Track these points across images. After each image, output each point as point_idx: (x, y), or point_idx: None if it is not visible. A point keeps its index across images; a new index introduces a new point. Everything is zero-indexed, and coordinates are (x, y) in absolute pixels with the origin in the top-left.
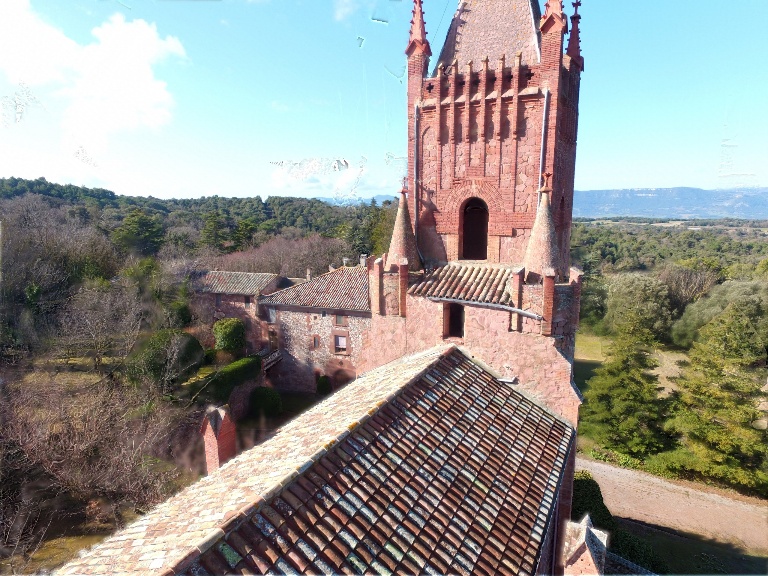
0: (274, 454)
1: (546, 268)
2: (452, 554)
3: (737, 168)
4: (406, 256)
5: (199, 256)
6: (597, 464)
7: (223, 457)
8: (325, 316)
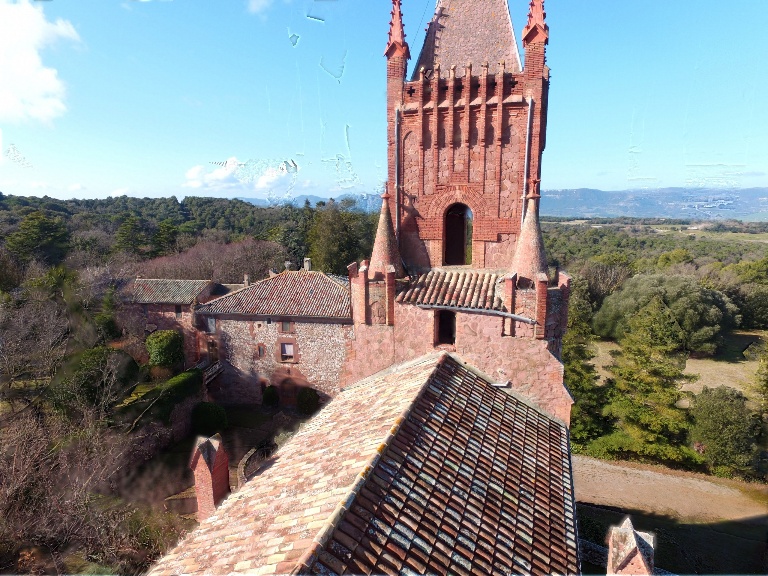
0: (292, 486)
1: (538, 273)
2: (507, 575)
3: (642, 173)
4: (391, 263)
5: (126, 264)
6: None
7: (217, 492)
8: (270, 323)
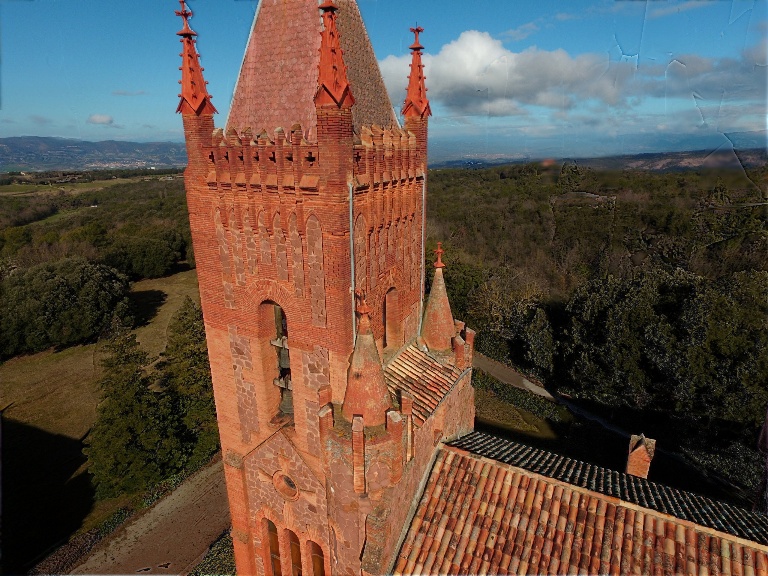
0: None
1: (467, 329)
2: (684, 501)
3: None
4: None
5: None
6: (158, 507)
7: None
8: None
